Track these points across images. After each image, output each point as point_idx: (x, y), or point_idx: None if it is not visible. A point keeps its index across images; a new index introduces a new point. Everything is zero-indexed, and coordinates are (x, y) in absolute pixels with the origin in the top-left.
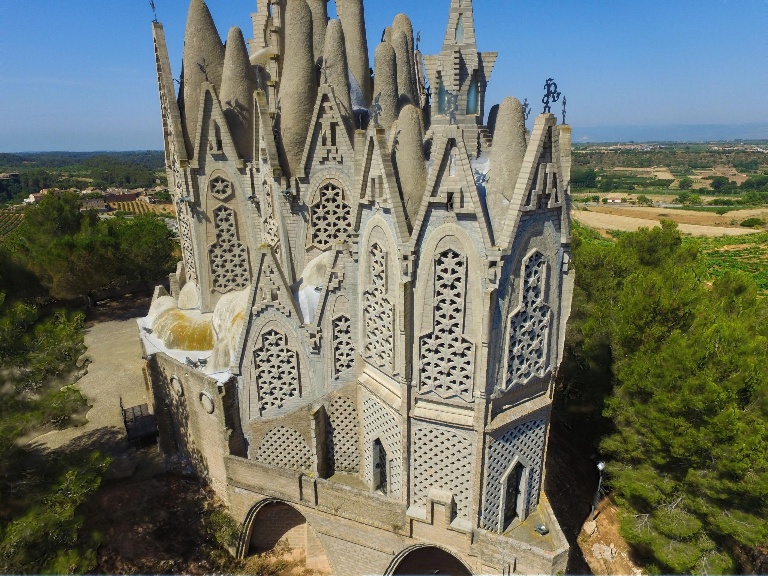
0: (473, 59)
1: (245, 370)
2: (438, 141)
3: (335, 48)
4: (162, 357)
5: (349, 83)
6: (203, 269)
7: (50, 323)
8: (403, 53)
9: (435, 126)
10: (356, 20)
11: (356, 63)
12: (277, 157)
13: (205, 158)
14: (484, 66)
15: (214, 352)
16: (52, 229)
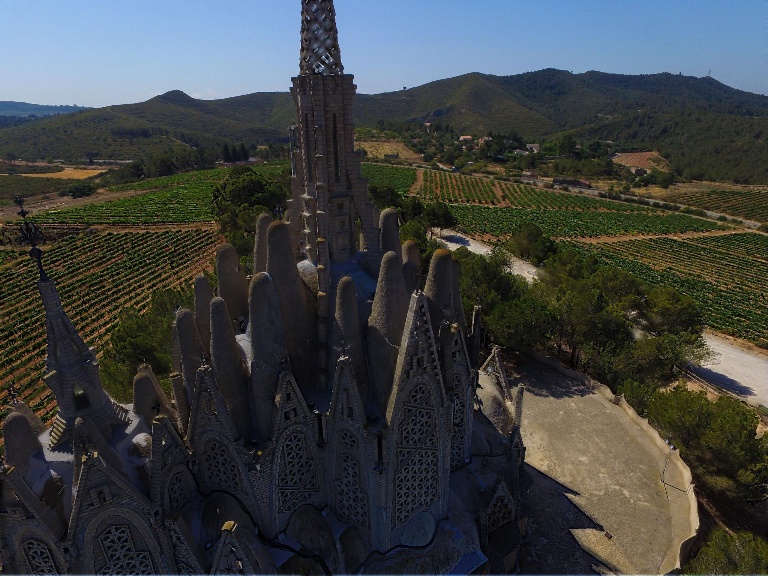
0: None
1: None
2: None
3: None
4: None
5: None
6: None
7: None
8: None
9: None
10: None
11: None
12: None
13: None
14: None
15: None
16: (468, 283)
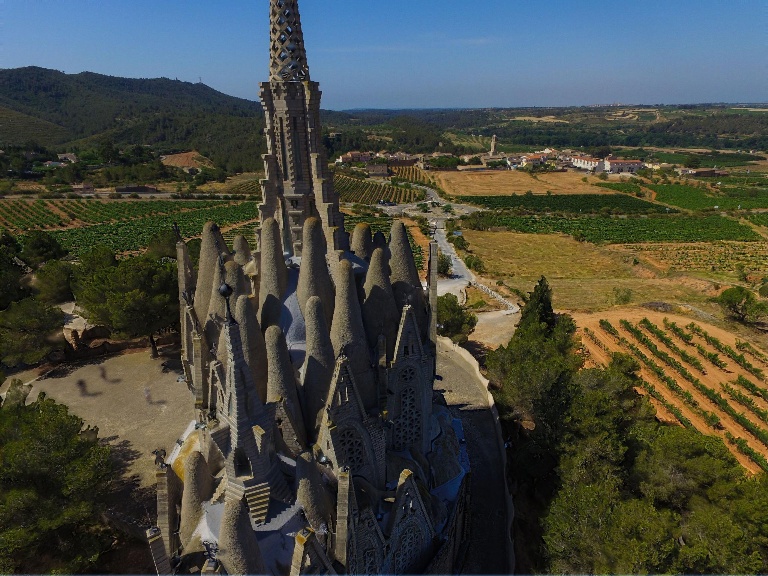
0: (235, 438)
1: None
2: None
3: None
4: None
5: (291, 320)
6: None
7: (88, 453)
8: (312, 321)
9: None
10: (307, 260)
11: (304, 299)
12: (202, 392)
13: (193, 355)
14: (256, 439)
15: None
16: None
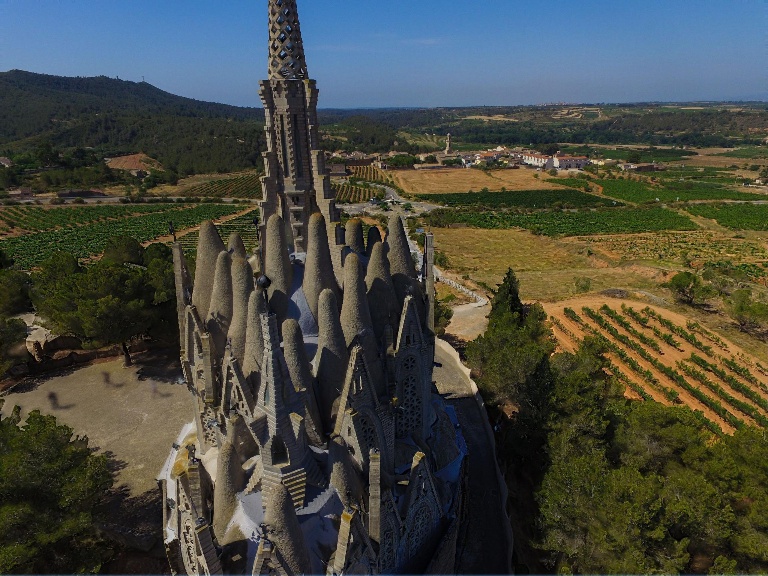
0: (273, 426)
1: (182, 539)
2: (254, 475)
3: (252, 317)
4: (162, 486)
5: (299, 314)
6: (199, 426)
7: (84, 462)
8: (326, 313)
9: (259, 457)
10: (314, 255)
11: (311, 293)
12: (212, 390)
13: (194, 355)
14: (293, 426)
15: (174, 511)
16: None
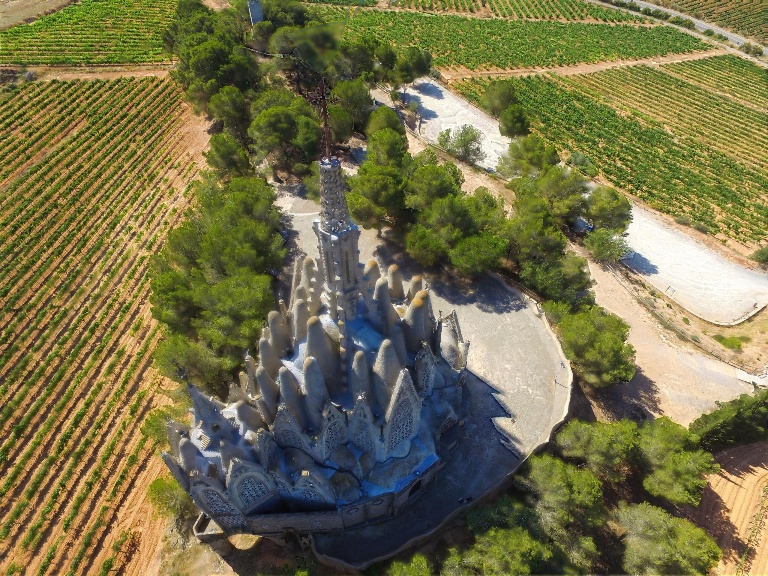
0: None
1: None
2: None
3: None
4: None
5: (297, 356)
6: None
7: None
8: None
9: None
10: None
11: None
12: None
13: None
14: None
15: None
16: (437, 218)
